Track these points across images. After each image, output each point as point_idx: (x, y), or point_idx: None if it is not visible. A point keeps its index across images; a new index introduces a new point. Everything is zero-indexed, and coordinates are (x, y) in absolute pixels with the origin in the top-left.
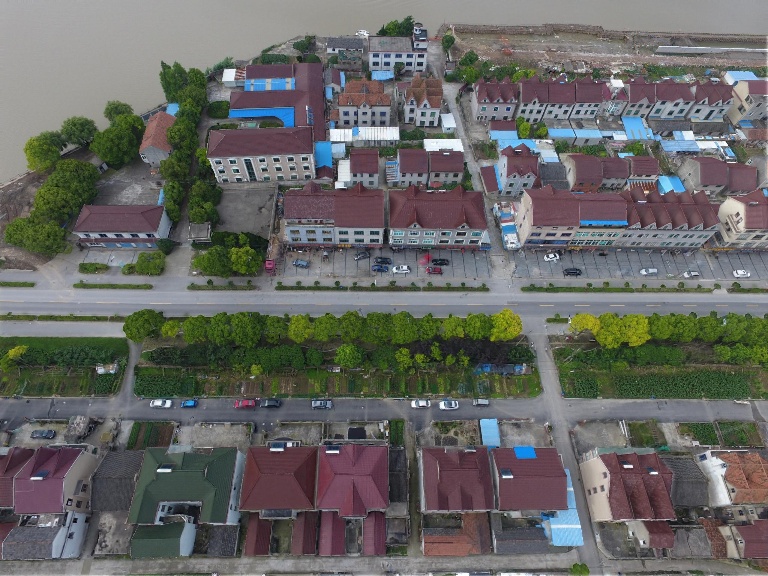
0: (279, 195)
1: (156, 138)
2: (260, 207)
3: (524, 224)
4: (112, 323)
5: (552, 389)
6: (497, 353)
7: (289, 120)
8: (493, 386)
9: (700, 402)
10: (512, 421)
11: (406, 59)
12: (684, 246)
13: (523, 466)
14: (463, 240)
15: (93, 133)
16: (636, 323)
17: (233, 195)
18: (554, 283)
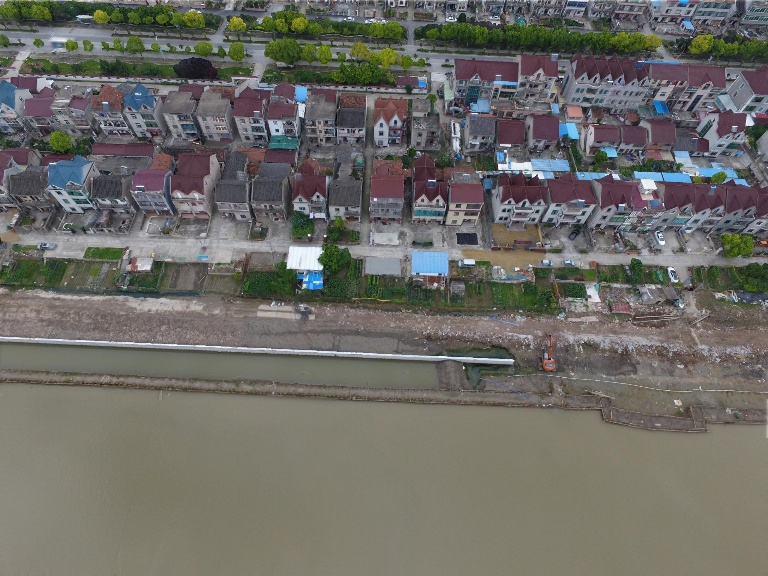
0: None
1: None
2: None
3: None
4: None
5: None
6: None
7: None
8: None
9: None
10: (675, 32)
11: None
12: None
13: None
14: None
15: None
16: None
17: None
18: None
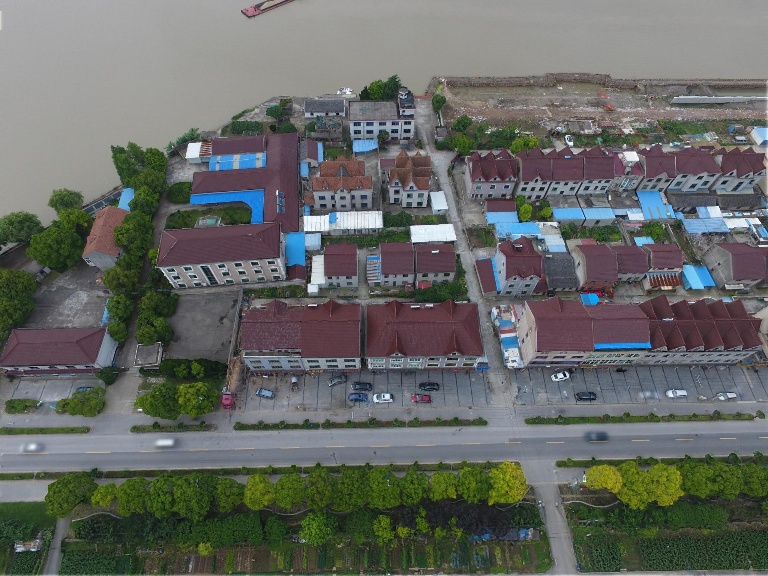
0: (244, 301)
1: (101, 240)
2: (221, 317)
3: (527, 343)
4: (38, 481)
5: (565, 560)
6: (497, 519)
7: (258, 206)
8: (493, 556)
9: (747, 573)
10: None
11: (391, 126)
12: (718, 362)
13: None
14: (455, 363)
15: (34, 230)
16: (666, 479)
17: (191, 302)
18: (564, 411)
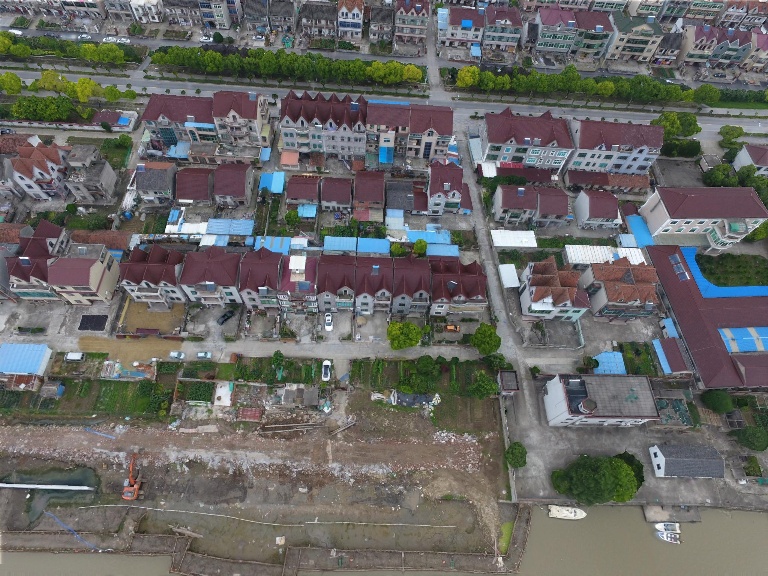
0: None
1: None
2: None
3: None
4: None
5: (432, 69)
6: None
7: (699, 280)
8: None
9: None
10: None
11: None
12: None
13: (471, 15)
14: None
15: None
16: None
17: None
18: None
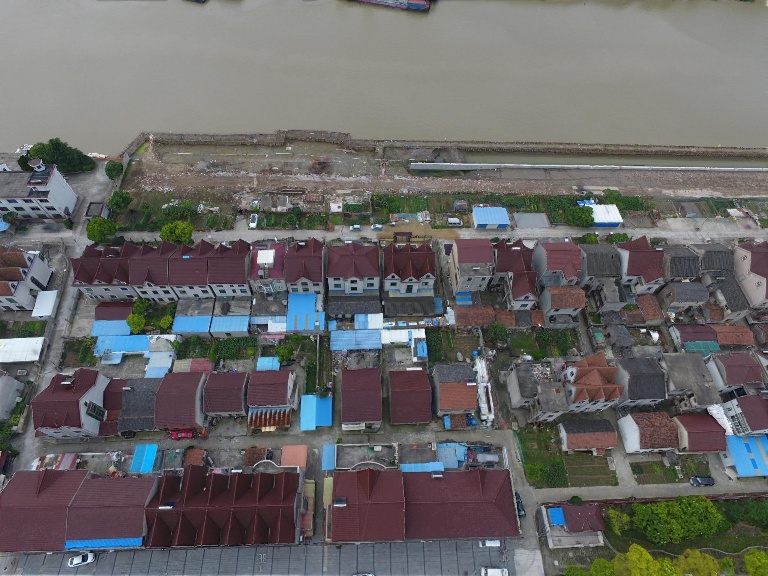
0: None
1: None
2: None
3: None
4: None
5: None
6: None
7: None
8: None
9: None
10: None
11: (26, 204)
12: None
13: None
14: None
15: None
16: None
17: None
18: None
